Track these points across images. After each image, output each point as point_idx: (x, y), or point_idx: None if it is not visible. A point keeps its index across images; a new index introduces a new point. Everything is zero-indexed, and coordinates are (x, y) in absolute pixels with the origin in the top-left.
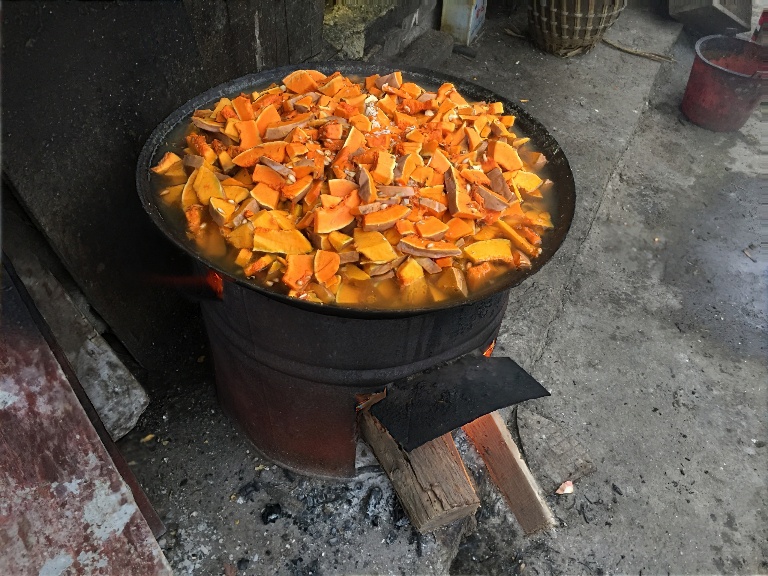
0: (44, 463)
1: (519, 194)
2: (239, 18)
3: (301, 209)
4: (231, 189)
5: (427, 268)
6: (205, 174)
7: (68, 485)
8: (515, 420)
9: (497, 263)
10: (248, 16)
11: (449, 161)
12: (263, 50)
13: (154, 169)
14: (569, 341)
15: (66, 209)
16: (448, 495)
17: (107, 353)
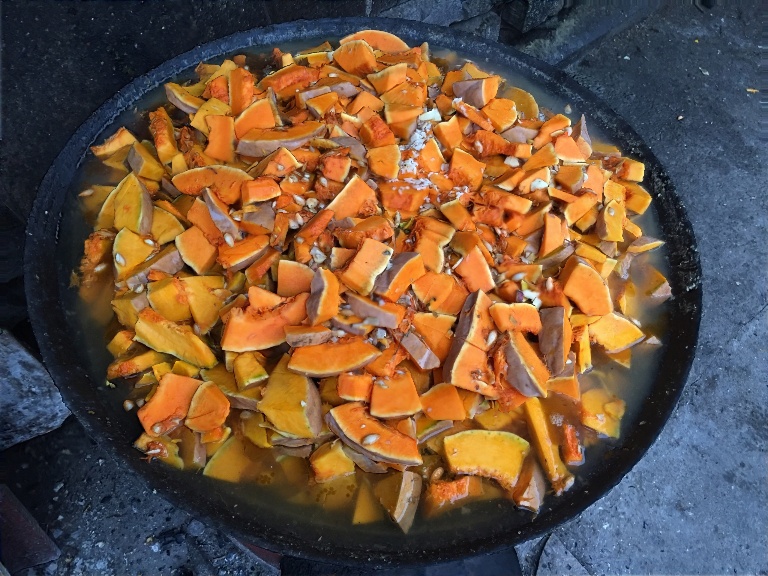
0: None
1: (588, 355)
2: None
3: (244, 279)
4: (163, 218)
5: (360, 465)
6: (132, 188)
7: None
8: (540, 552)
9: (488, 481)
10: None
11: (491, 270)
12: None
13: (94, 149)
14: (664, 462)
15: (15, 157)
16: None
17: (19, 352)
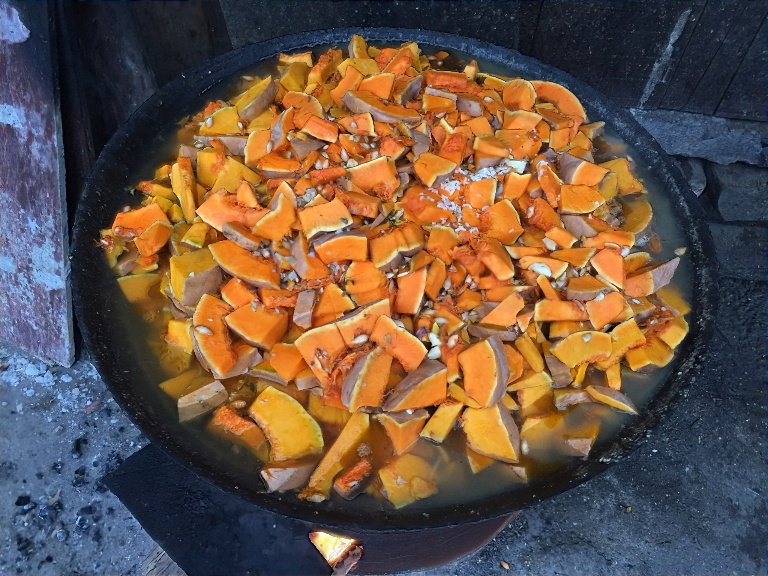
0: (22, 190)
1: (443, 429)
2: (651, 2)
3: None
4: (267, 118)
5: (195, 349)
6: (263, 85)
7: (30, 221)
8: None
9: None
10: (670, 8)
11: (425, 299)
12: (674, 63)
13: (282, 56)
14: None
15: None
16: (164, 574)
17: None
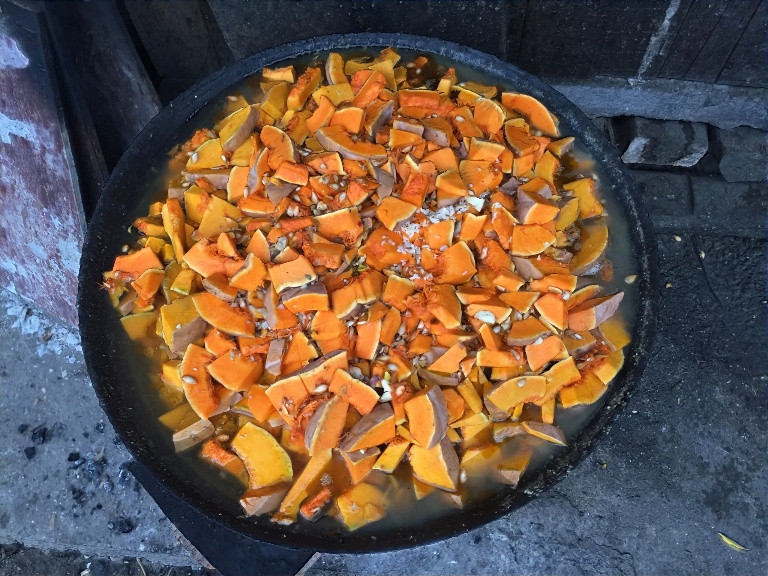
0: (42, 192)
1: (392, 462)
2: None
3: None
4: (248, 148)
5: None
6: (243, 115)
7: (53, 218)
8: None
9: None
10: None
11: (380, 346)
12: (671, 37)
13: (264, 71)
14: None
15: (255, 40)
16: None
17: None
